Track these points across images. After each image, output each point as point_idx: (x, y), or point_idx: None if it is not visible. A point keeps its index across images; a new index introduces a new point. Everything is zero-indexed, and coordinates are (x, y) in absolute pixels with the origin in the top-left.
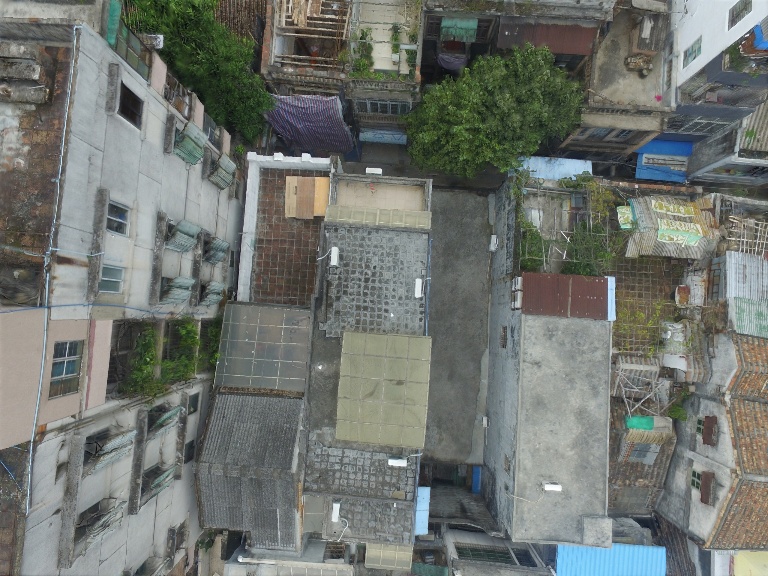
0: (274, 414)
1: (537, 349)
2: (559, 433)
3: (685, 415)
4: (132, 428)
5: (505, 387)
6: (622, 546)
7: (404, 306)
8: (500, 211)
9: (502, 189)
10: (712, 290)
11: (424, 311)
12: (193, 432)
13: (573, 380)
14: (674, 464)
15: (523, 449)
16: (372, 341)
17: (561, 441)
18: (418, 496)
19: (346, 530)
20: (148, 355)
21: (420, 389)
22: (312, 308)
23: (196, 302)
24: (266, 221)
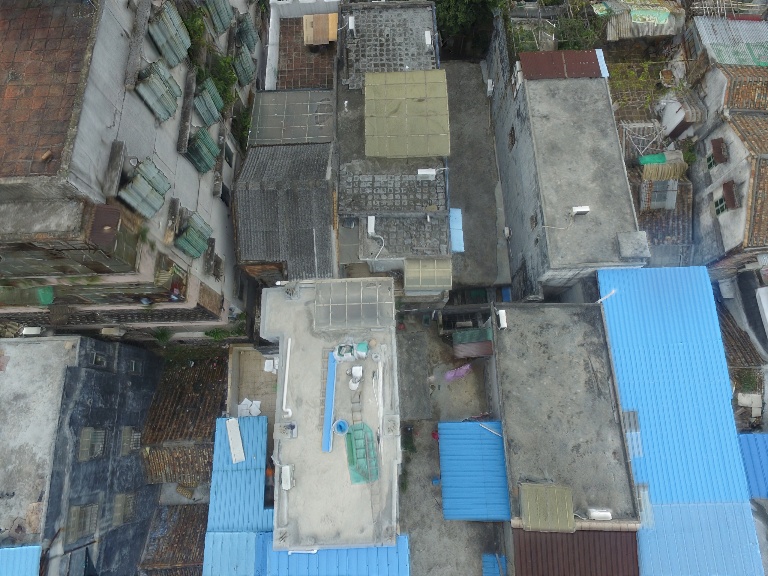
0: (305, 153)
1: (543, 106)
2: (577, 170)
3: (694, 156)
4: (182, 78)
5: (520, 167)
6: (662, 269)
7: (417, 60)
8: (492, 60)
9: (491, 43)
10: (690, 54)
11: (435, 62)
12: (229, 179)
13: (581, 126)
14: (696, 213)
15: (546, 187)
16: (392, 76)
17: (581, 176)
18: (450, 216)
19: (383, 250)
20: (198, 18)
21: (440, 102)
22: (335, 66)
23: (232, 57)
24: (287, 57)
